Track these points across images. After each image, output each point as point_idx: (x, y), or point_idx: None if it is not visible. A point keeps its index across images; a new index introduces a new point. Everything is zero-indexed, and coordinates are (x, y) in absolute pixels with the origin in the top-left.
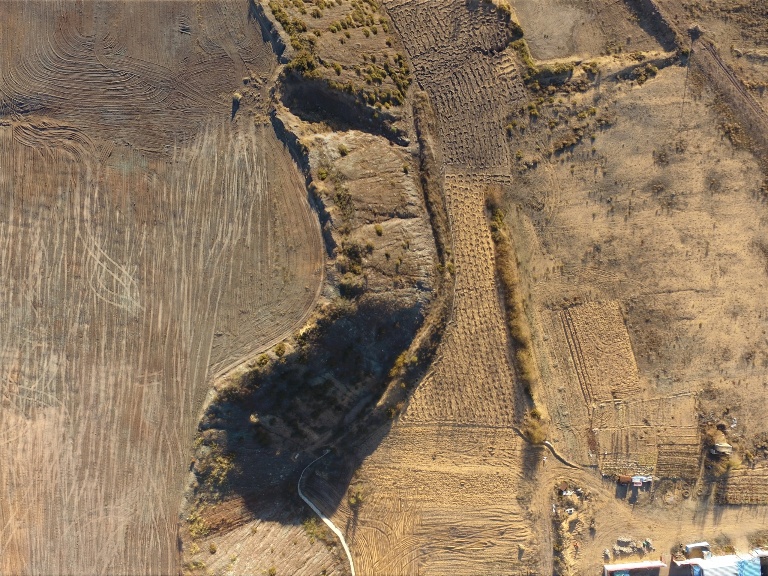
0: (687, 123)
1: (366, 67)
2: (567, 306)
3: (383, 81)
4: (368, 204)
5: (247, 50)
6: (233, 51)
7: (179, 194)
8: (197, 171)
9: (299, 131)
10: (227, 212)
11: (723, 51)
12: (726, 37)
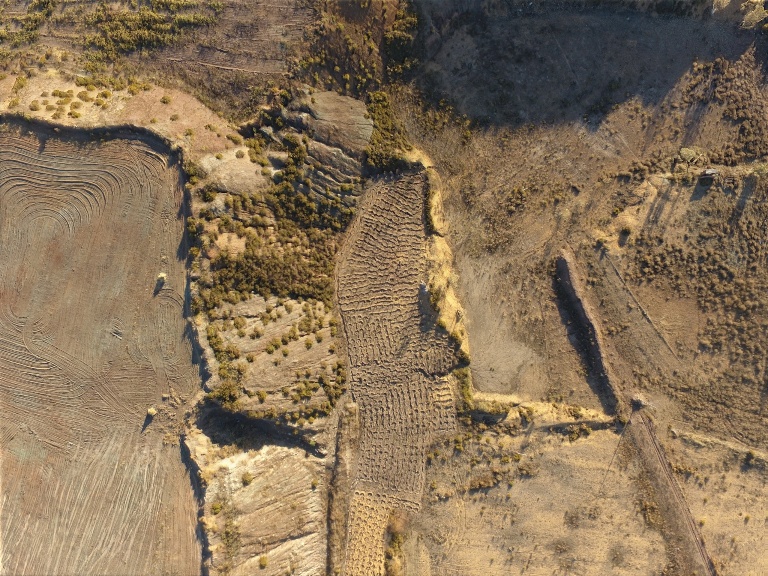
0: (606, 491)
1: (297, 385)
2: None
3: (313, 395)
4: (258, 538)
5: (173, 368)
6: (159, 366)
7: (70, 494)
8: (94, 475)
9: (204, 460)
10: (113, 523)
11: (660, 429)
12: (667, 415)
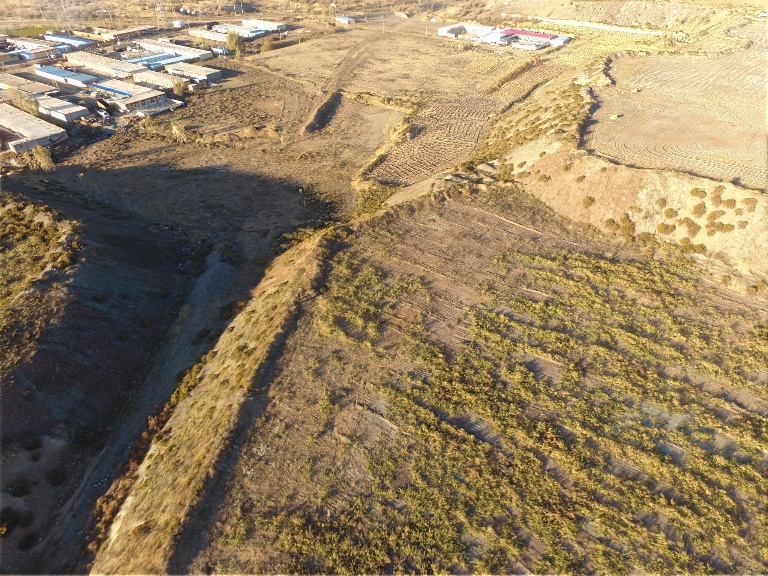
0: None
1: None
2: (485, 73)
3: None
4: None
5: None
6: None
7: None
8: None
9: None
10: None
11: None
12: None
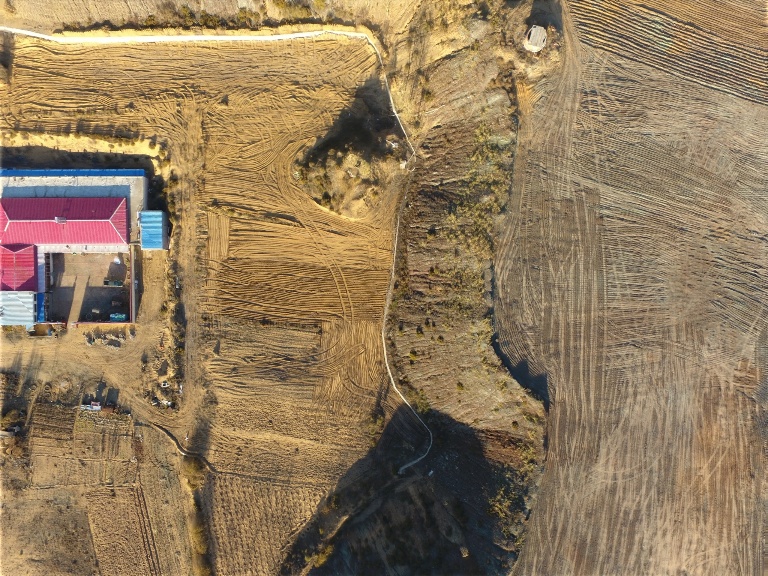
0: None
1: None
2: None
3: None
4: None
5: None
6: None
7: None
8: None
9: None
10: None
11: None
12: None
